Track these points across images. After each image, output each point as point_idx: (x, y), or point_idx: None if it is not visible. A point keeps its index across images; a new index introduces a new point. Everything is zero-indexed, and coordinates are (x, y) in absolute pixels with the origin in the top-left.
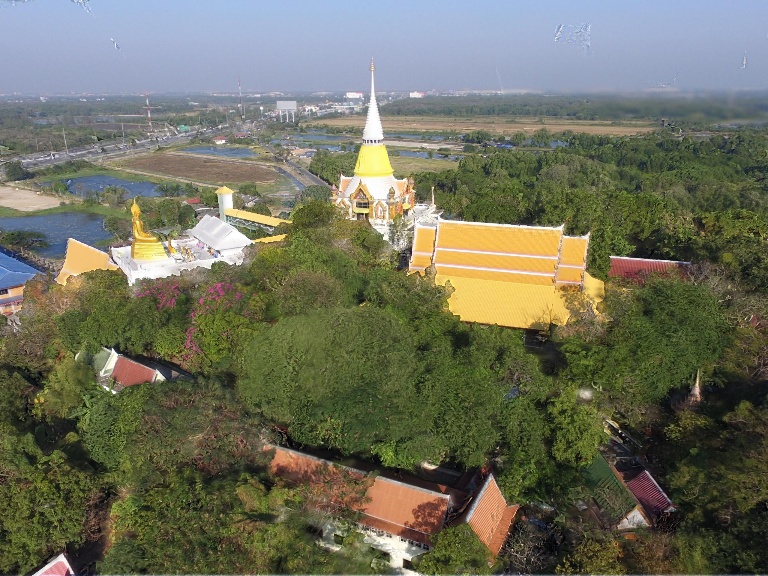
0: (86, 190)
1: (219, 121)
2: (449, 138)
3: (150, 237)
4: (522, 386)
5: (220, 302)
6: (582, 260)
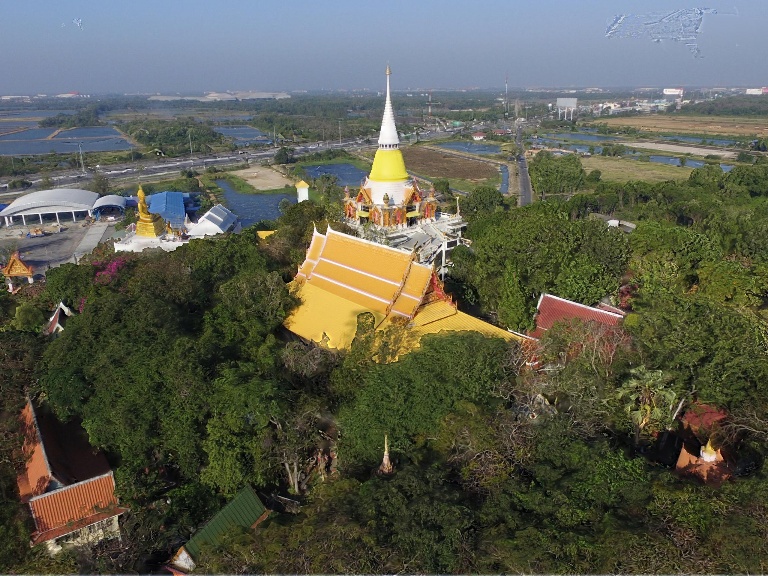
0: (307, 176)
1: (482, 118)
2: (735, 144)
3: (147, 218)
4: (175, 399)
5: (107, 277)
6: (421, 291)
